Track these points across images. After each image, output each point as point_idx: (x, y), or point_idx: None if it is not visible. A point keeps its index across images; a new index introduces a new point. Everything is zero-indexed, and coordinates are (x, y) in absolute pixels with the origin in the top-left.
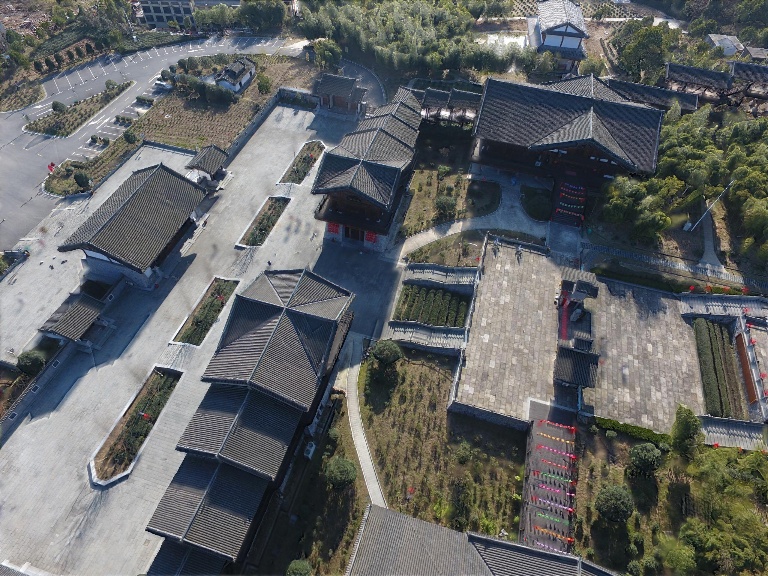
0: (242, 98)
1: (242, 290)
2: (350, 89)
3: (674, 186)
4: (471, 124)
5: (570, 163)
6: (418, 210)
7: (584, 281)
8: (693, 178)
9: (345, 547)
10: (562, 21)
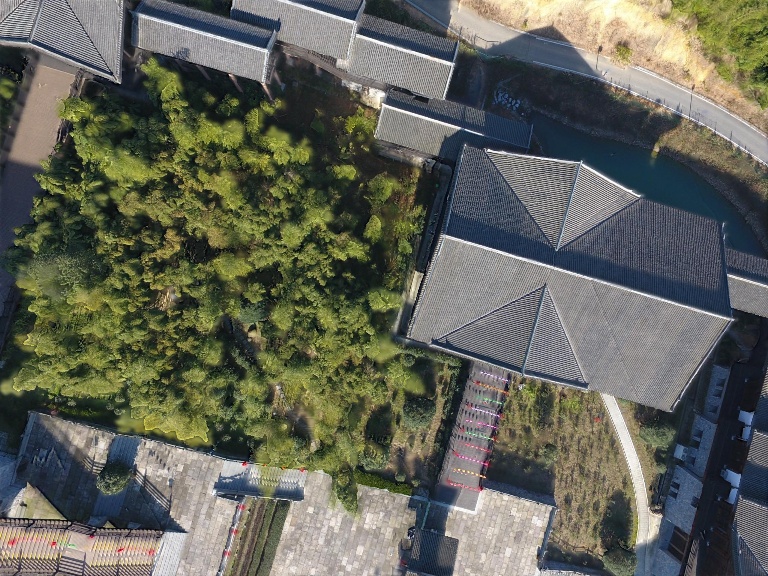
0: None
1: None
2: None
3: None
4: None
5: None
6: None
7: None
8: None
9: None
10: None
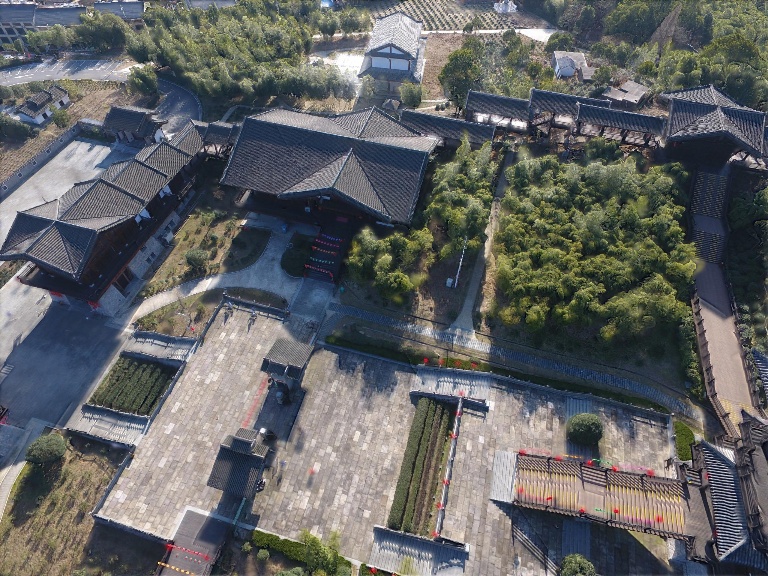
0: (44, 131)
1: None
2: (138, 123)
3: (426, 240)
4: None
5: (334, 210)
6: (173, 264)
7: (276, 362)
8: (449, 230)
9: None
10: (387, 41)
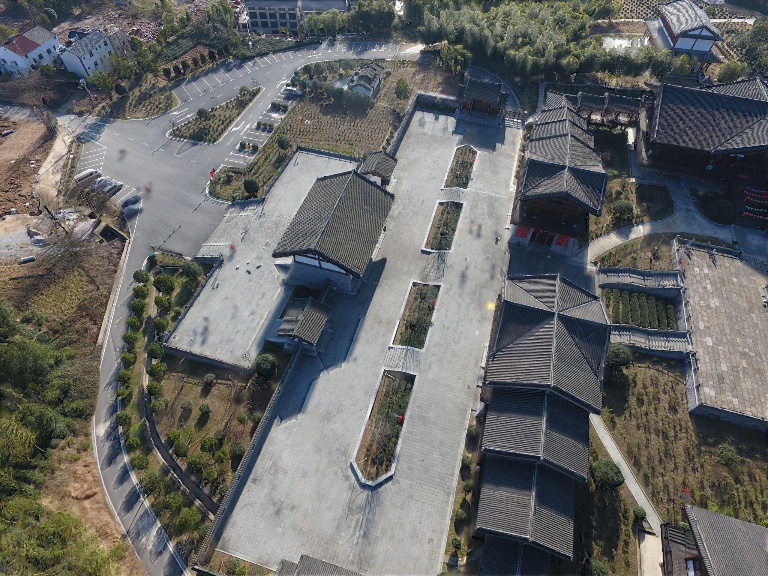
0: (377, 103)
1: (503, 295)
2: (497, 94)
3: None
4: (619, 128)
5: (747, 167)
6: None
7: None
8: None
9: (625, 547)
10: (696, 24)
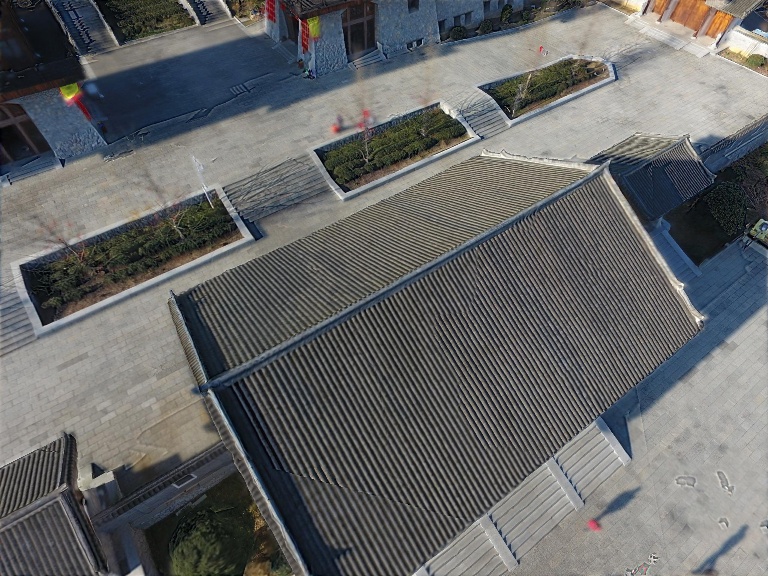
0: None
1: None
2: None
3: None
4: None
5: None
6: None
7: None
8: None
9: None
10: None
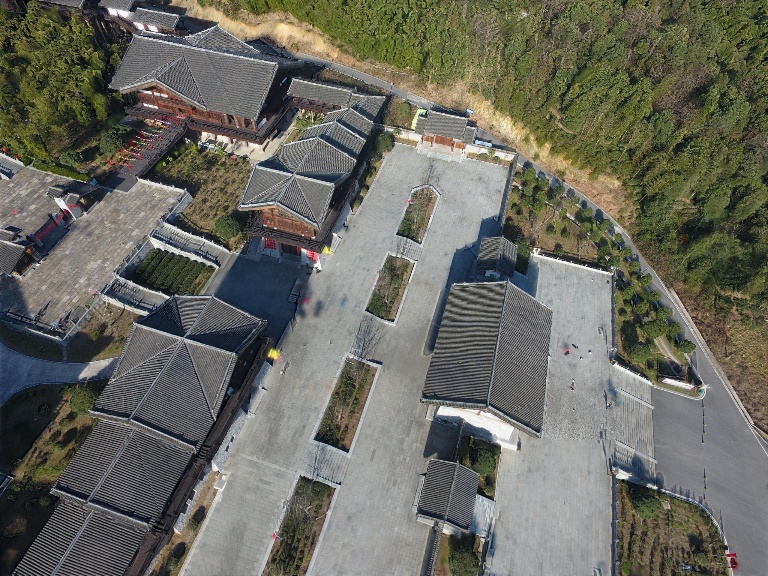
0: None
1: None
2: None
3: None
4: None
5: None
6: None
7: None
8: None
9: None
10: None
